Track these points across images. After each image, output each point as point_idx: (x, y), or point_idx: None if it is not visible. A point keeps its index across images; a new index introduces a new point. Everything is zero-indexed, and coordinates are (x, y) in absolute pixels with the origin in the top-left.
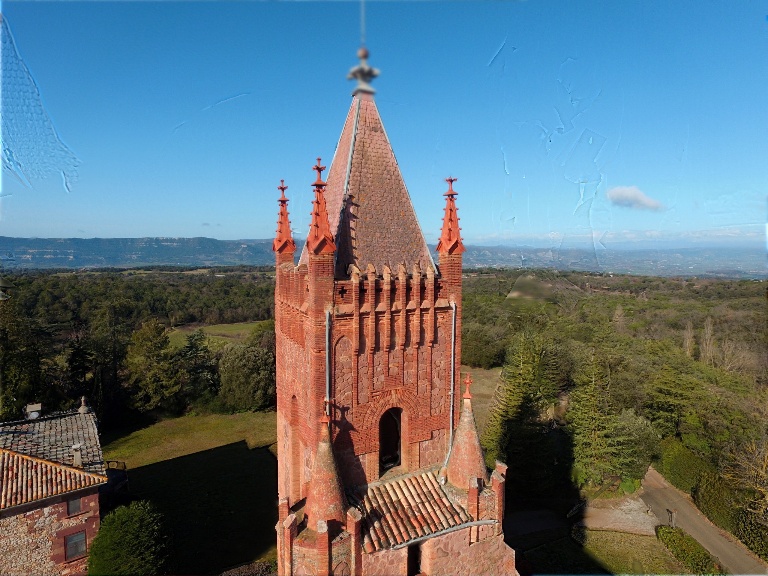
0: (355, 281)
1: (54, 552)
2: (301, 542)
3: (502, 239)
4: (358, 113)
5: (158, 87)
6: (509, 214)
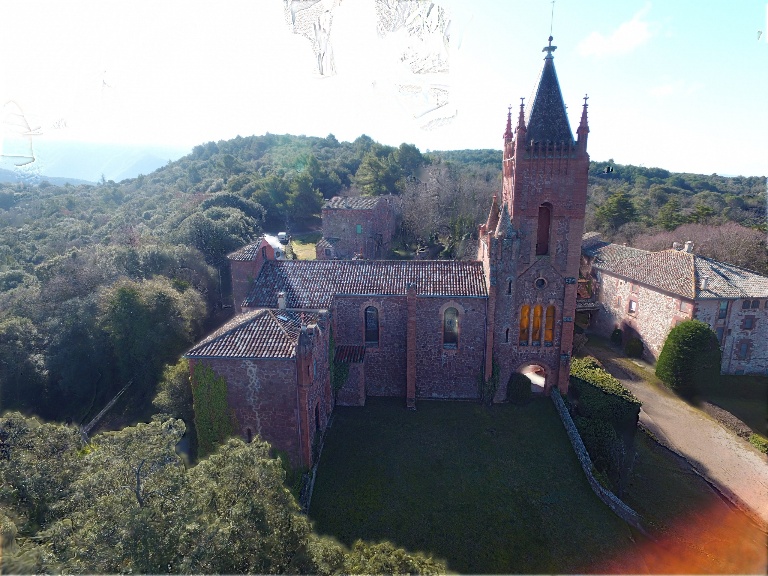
0: None
1: (672, 326)
2: None
3: None
4: None
5: (414, 126)
6: None
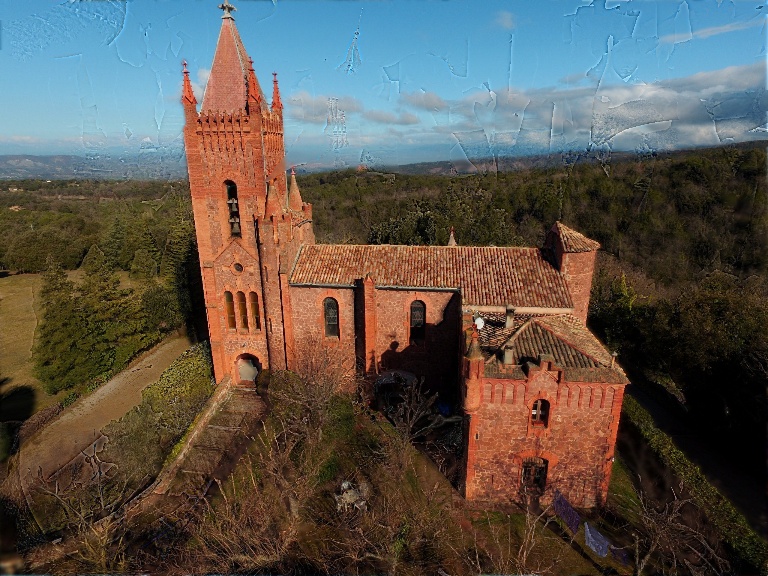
0: (266, 117)
1: None
2: (280, 221)
3: (87, 126)
4: (233, 31)
5: None
6: (90, 101)
